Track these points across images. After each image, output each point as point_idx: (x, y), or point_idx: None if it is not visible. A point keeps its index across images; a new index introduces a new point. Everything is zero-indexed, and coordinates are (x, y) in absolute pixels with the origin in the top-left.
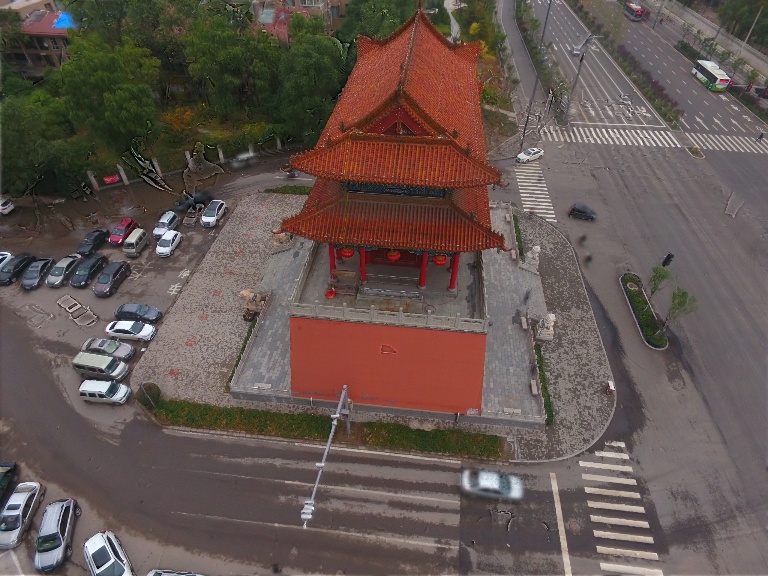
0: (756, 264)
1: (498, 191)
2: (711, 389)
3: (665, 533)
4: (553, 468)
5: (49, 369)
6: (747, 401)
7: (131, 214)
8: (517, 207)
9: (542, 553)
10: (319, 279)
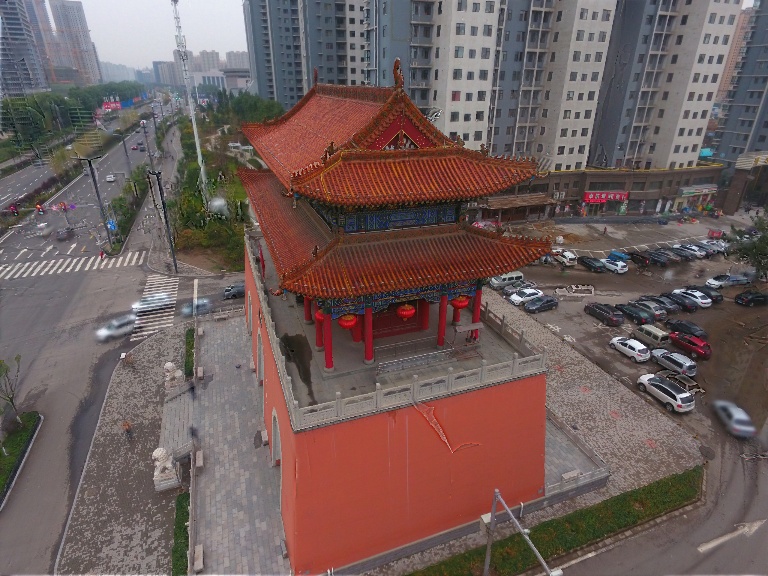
0: None
1: None
2: None
3: (129, 313)
4: (194, 318)
5: None
6: None
7: (742, 368)
8: None
9: (209, 295)
10: None
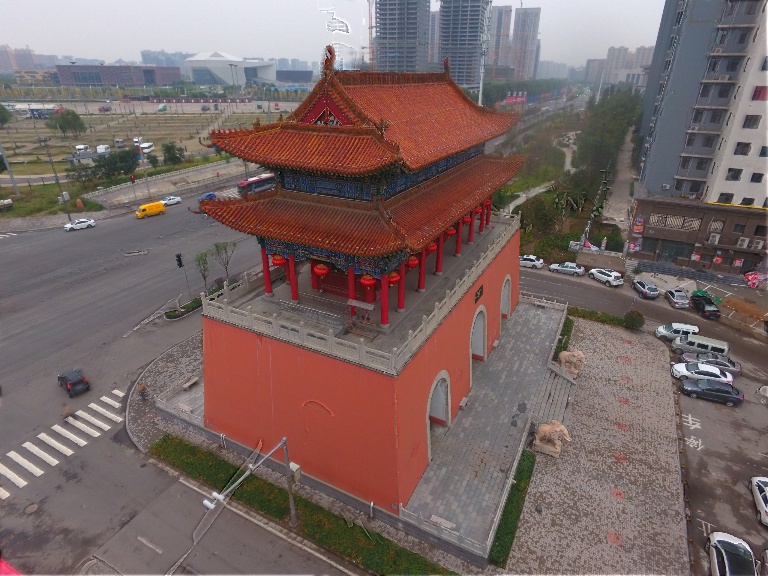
0: (43, 303)
1: (91, 476)
2: (242, 268)
3: None
4: None
5: (762, 369)
6: (233, 262)
7: None
8: (122, 428)
9: None
10: (498, 233)
